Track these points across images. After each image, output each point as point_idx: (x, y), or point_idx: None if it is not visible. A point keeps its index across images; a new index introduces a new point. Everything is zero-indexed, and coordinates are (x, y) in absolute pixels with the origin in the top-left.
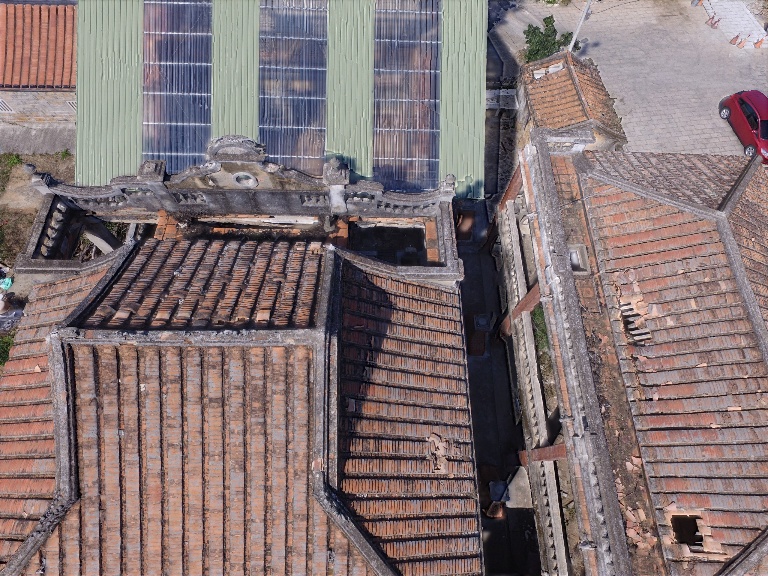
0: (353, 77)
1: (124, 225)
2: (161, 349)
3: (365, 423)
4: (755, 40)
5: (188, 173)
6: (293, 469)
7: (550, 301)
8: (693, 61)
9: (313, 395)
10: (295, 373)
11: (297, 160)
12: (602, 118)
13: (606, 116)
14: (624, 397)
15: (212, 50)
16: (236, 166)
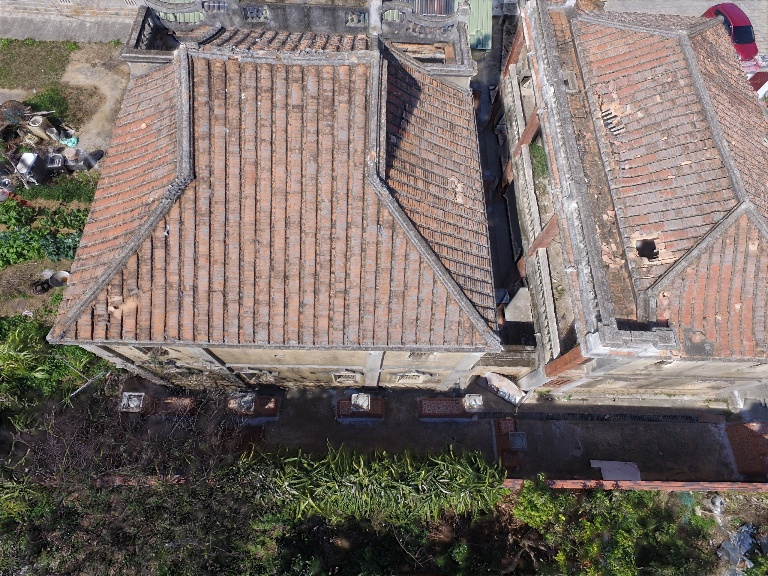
0: None
1: None
2: (257, 67)
3: (403, 153)
4: None
5: None
6: (353, 163)
7: (545, 112)
8: None
9: (369, 105)
10: (356, 86)
11: None
12: None
13: None
14: (603, 173)
15: None
16: None
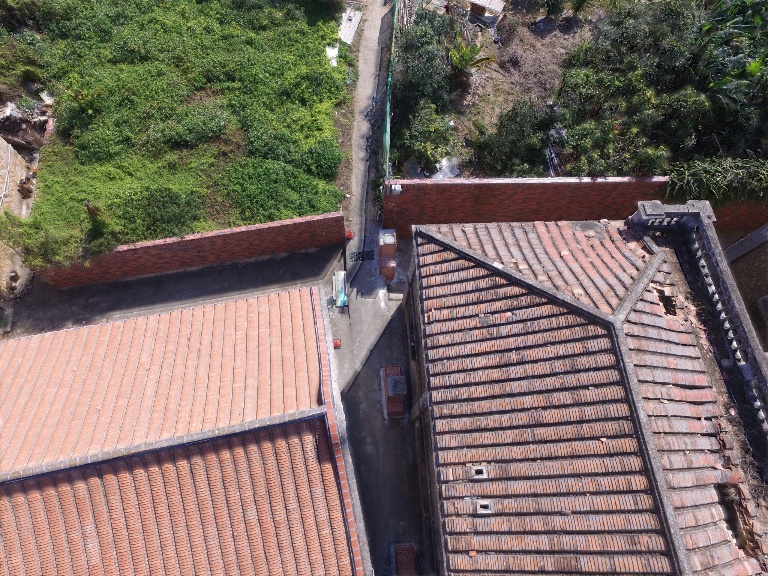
0: None
1: None
2: None
3: None
4: None
5: None
6: None
7: None
8: None
9: None
10: None
11: None
12: None
13: None
14: None
15: None
16: None
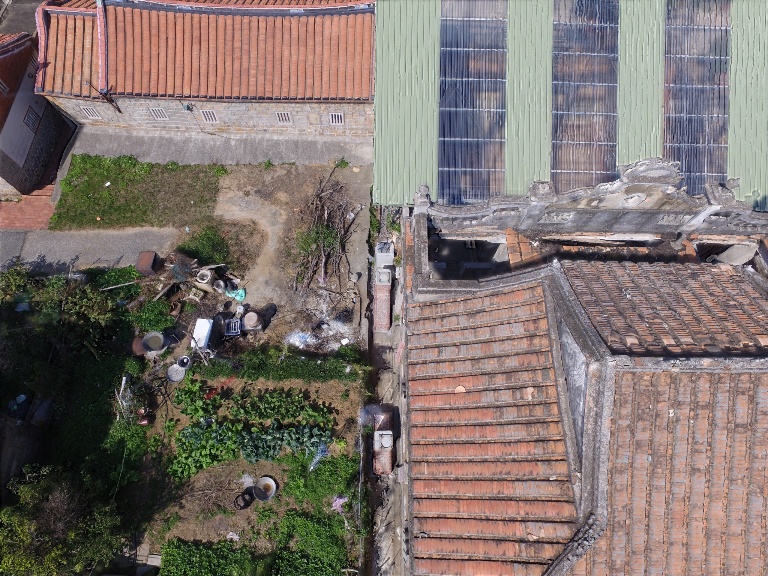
0: (644, 92)
1: (344, 236)
2: (693, 375)
3: None
4: None
5: (583, 194)
6: None
7: None
8: None
9: None
10: None
11: (589, 175)
12: None
13: None
14: None
15: (507, 66)
16: (641, 187)
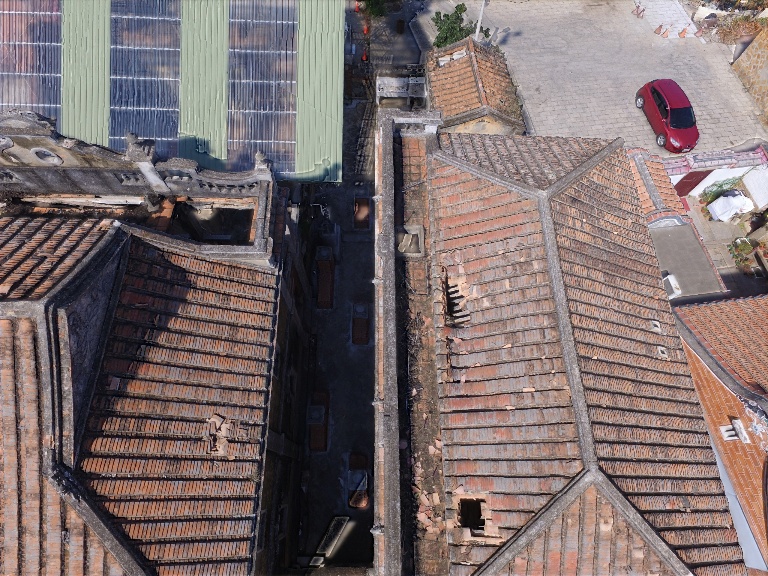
0: (207, 58)
1: None
2: None
3: (129, 402)
4: (680, 30)
5: None
6: (25, 447)
7: (381, 283)
8: (615, 50)
9: (41, 370)
10: (21, 347)
11: None
12: (500, 105)
13: (505, 103)
14: None
15: (62, 30)
16: (28, 141)
